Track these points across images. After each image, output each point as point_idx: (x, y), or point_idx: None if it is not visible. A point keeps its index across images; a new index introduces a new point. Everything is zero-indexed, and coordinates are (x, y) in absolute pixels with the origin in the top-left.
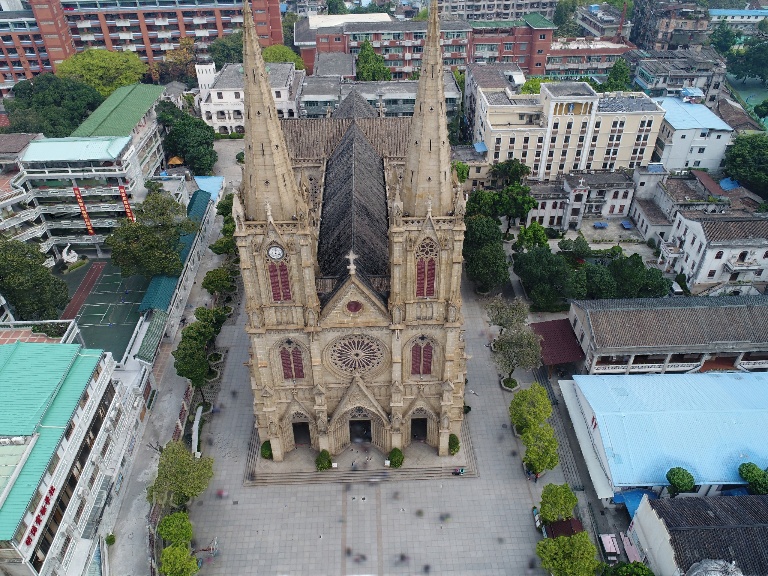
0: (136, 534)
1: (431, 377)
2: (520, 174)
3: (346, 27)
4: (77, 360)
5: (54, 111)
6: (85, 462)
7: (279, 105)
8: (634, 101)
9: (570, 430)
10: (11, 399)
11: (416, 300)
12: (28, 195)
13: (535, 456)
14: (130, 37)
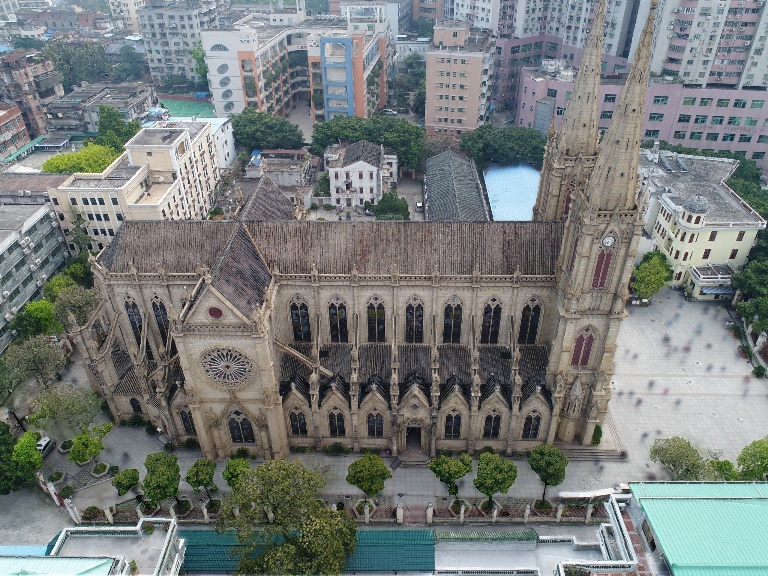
0: None
1: None
2: None
3: None
4: None
5: None
6: None
7: None
8: (178, 127)
9: None
10: (762, 536)
11: None
12: None
13: None
14: None
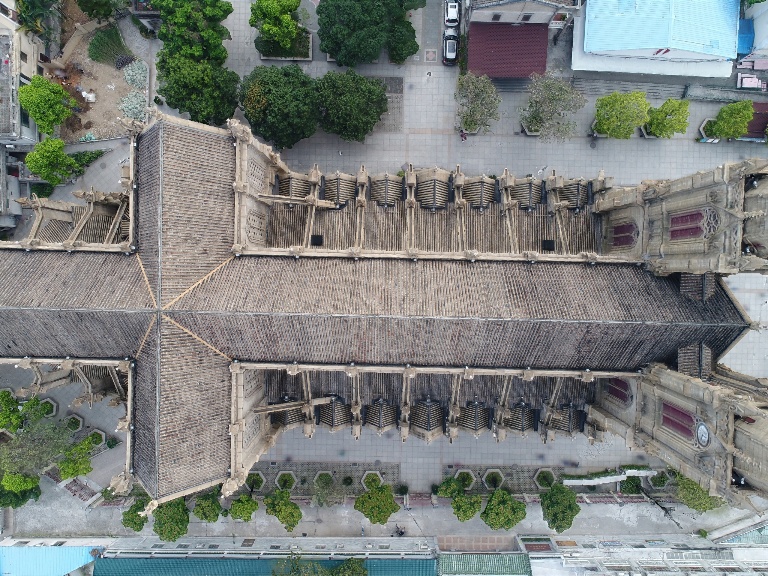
0: None
1: None
2: None
3: None
4: None
5: None
6: None
7: None
8: None
9: (613, 76)
10: None
11: None
12: None
13: None
14: None
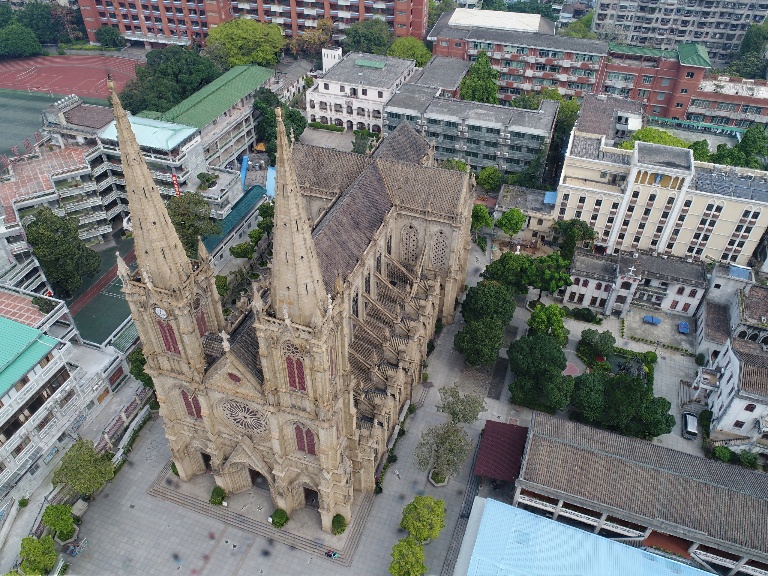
0: (45, 505)
1: (314, 459)
2: (582, 238)
3: (471, 32)
4: (34, 345)
5: (165, 85)
6: (12, 435)
7: (378, 106)
8: (748, 183)
9: None
10: None
11: (288, 390)
12: (101, 167)
13: (395, 573)
14: (280, 10)
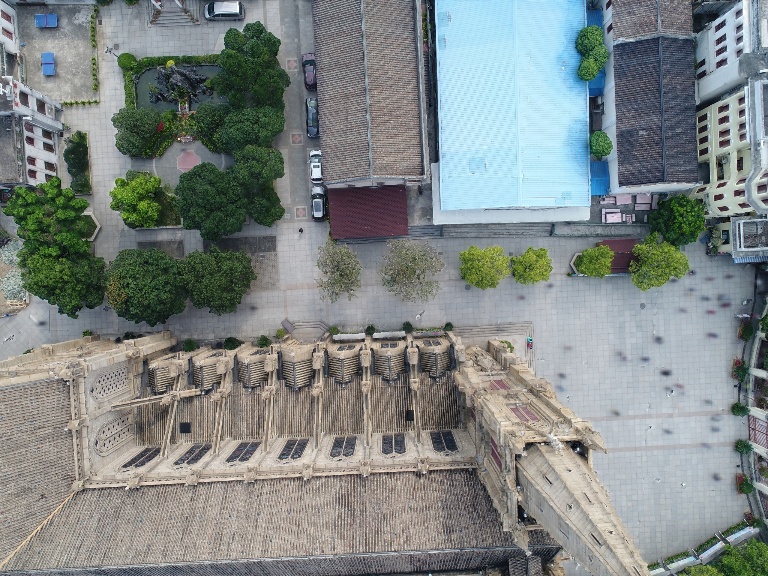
0: None
1: None
2: None
3: None
4: None
5: None
6: None
7: None
8: None
9: None
10: None
11: None
12: None
13: None
14: None
